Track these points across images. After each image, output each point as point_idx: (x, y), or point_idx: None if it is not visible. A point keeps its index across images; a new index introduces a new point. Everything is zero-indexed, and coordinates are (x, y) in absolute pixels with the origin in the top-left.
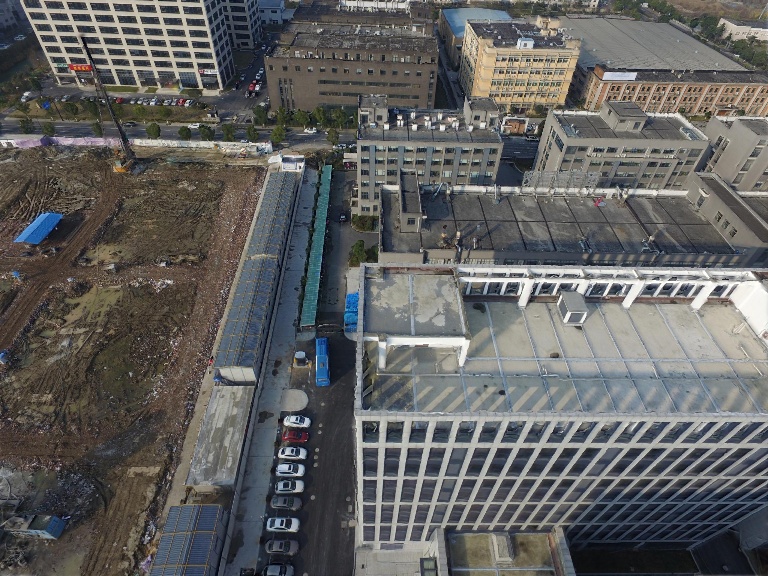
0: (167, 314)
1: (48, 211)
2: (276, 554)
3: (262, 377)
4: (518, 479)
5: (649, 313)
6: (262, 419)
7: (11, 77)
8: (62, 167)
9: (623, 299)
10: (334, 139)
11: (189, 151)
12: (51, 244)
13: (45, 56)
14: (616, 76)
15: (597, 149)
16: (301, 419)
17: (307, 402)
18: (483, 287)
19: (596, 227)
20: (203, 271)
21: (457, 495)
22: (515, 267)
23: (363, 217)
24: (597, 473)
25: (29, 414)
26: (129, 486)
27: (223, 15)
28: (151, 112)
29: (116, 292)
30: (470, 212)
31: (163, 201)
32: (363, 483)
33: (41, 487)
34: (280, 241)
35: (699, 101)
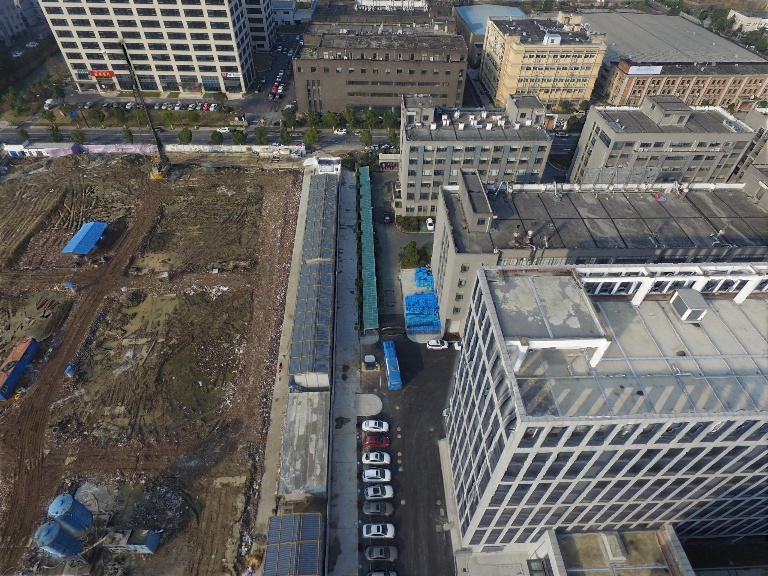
0: (227, 321)
1: (89, 220)
2: (377, 561)
3: (333, 382)
4: (652, 479)
5: (762, 308)
6: (339, 425)
7: (30, 85)
8: (96, 175)
9: (735, 295)
10: (367, 140)
11: (221, 156)
12: (98, 254)
13: (65, 63)
14: (642, 70)
15: (644, 144)
16: (380, 423)
17: (382, 406)
18: (596, 287)
19: (662, 222)
20: (256, 277)
21: (584, 496)
22: (632, 266)
23: (407, 218)
24: (732, 470)
25: (104, 427)
26: (218, 497)
27: (244, 17)
28: (177, 117)
29: (172, 300)
30: (534, 211)
31: (204, 207)
32: (496, 488)
33: (128, 501)
34: (333, 244)
35: (722, 93)
